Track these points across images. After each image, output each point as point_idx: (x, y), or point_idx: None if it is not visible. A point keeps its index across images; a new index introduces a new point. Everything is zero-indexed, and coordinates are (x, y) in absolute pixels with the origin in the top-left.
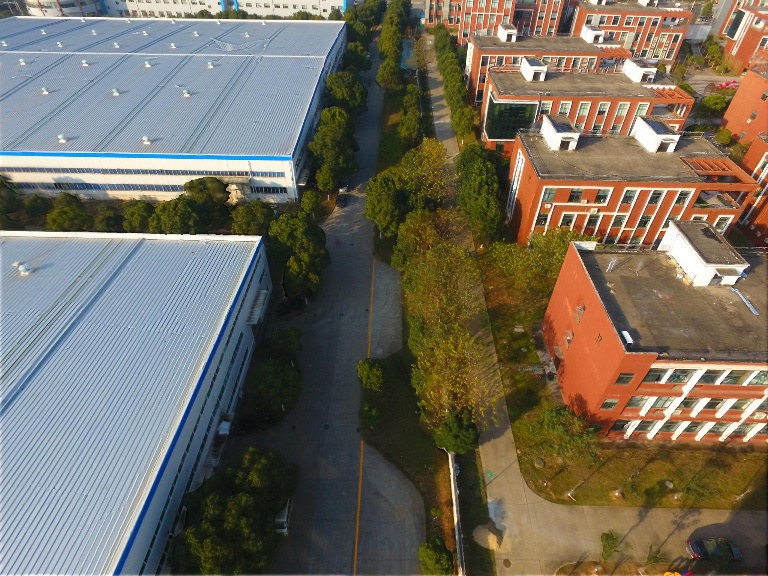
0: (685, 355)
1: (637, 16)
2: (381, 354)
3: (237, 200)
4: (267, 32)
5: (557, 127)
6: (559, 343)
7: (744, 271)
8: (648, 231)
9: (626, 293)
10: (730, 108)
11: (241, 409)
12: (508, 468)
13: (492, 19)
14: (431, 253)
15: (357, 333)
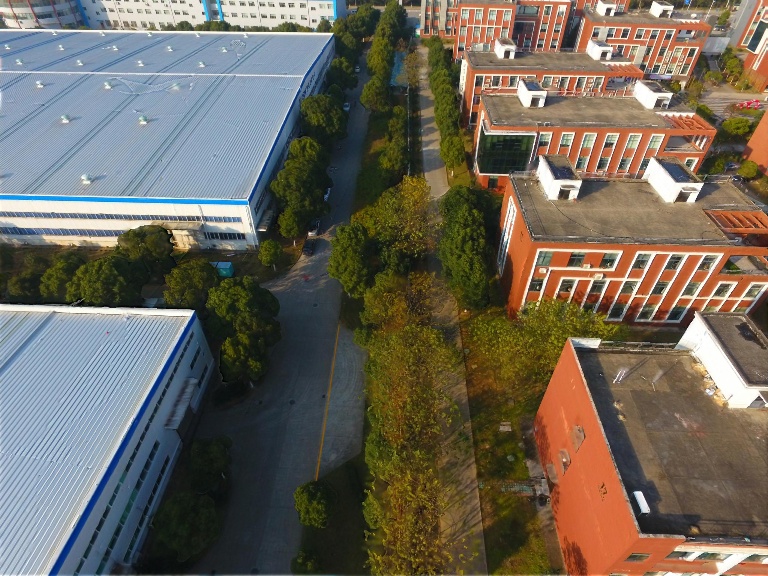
0: (722, 531)
1: (649, 28)
2: (334, 461)
3: (190, 246)
4: (247, 46)
5: (555, 171)
6: (553, 460)
7: None
8: (664, 298)
9: (639, 419)
10: (755, 135)
11: (151, 543)
12: None
13: (490, 32)
14: (395, 340)
15: (308, 429)
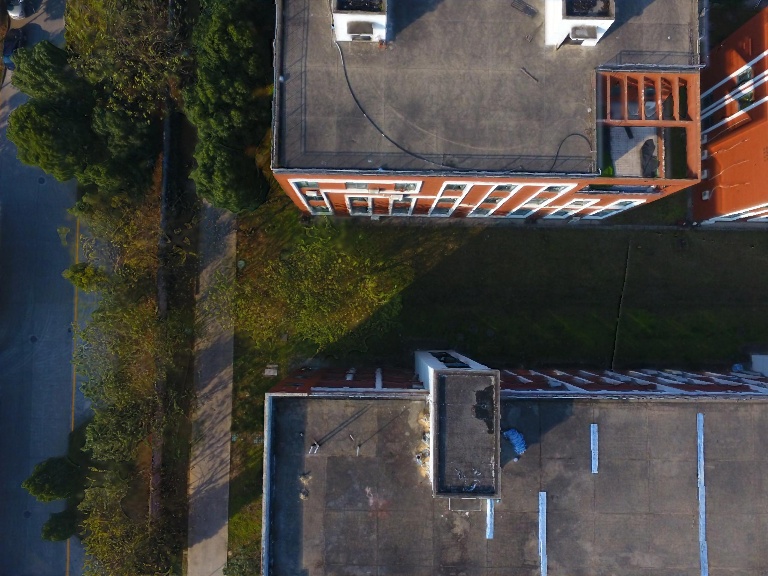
0: None
1: None
2: (89, 409)
3: None
4: None
5: None
6: None
7: (526, 441)
8: None
9: (322, 497)
10: None
11: None
12: (214, 574)
13: None
14: None
15: (56, 374)
